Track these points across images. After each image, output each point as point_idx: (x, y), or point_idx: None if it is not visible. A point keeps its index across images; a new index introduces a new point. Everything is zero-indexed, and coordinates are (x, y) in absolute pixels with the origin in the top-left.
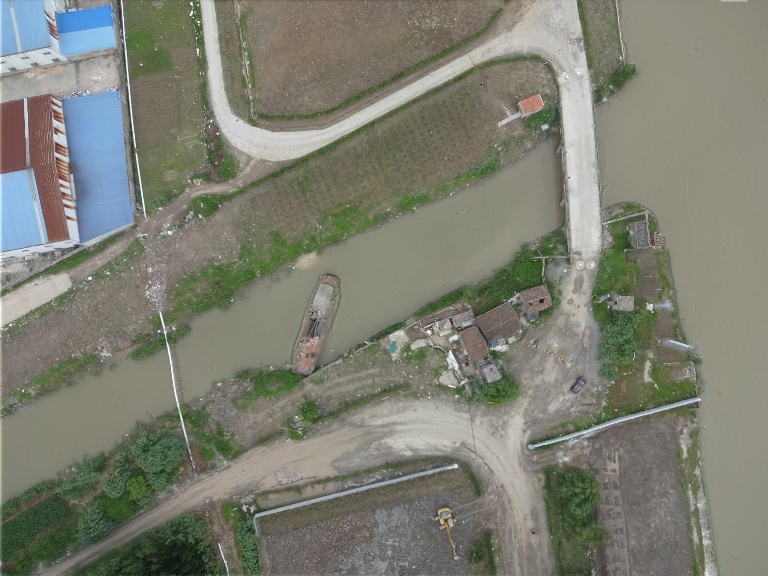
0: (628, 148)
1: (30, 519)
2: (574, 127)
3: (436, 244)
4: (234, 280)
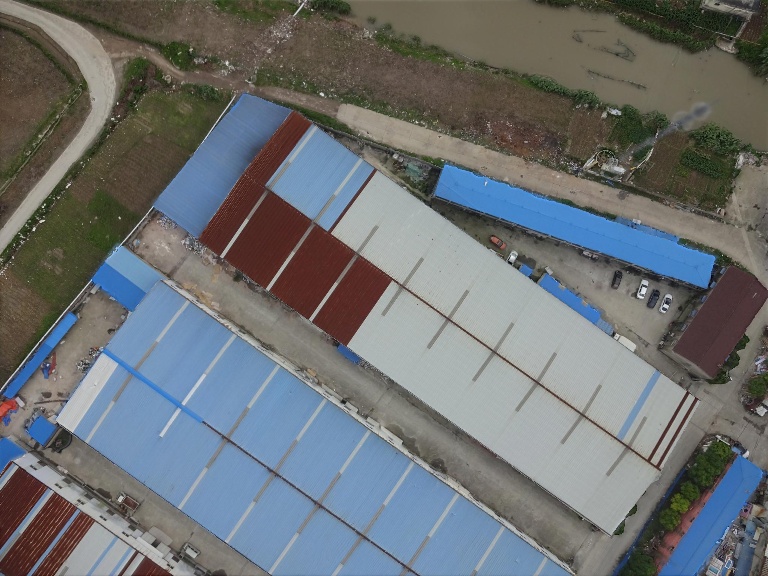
0: None
1: None
2: None
3: None
4: None
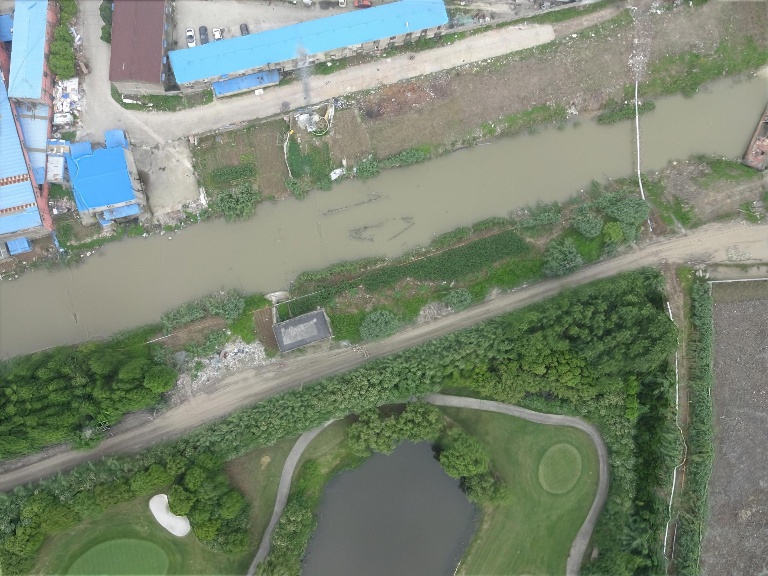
0: None
1: (488, 246)
2: None
3: None
4: (707, 70)
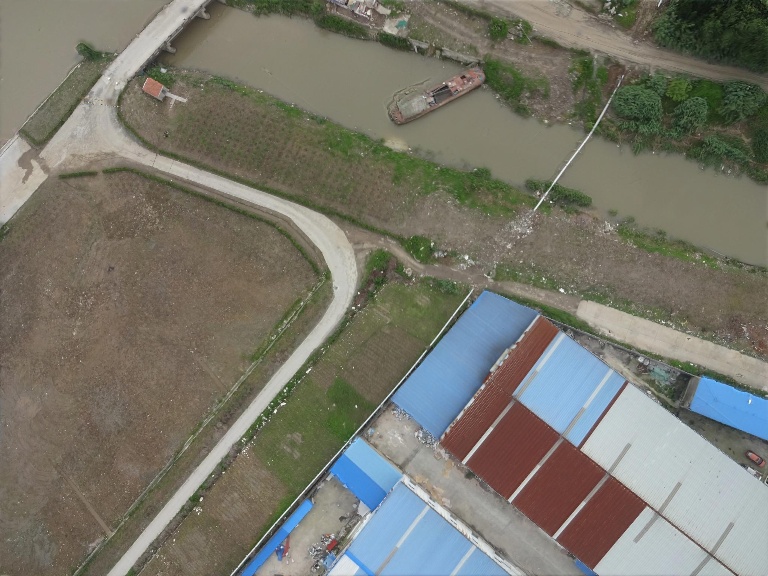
0: (136, 8)
1: None
2: (148, 48)
3: (305, 68)
4: (458, 178)
